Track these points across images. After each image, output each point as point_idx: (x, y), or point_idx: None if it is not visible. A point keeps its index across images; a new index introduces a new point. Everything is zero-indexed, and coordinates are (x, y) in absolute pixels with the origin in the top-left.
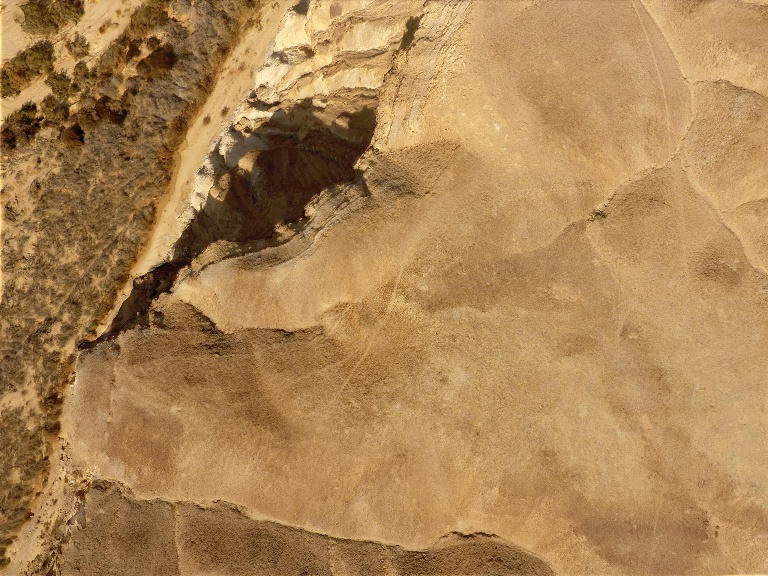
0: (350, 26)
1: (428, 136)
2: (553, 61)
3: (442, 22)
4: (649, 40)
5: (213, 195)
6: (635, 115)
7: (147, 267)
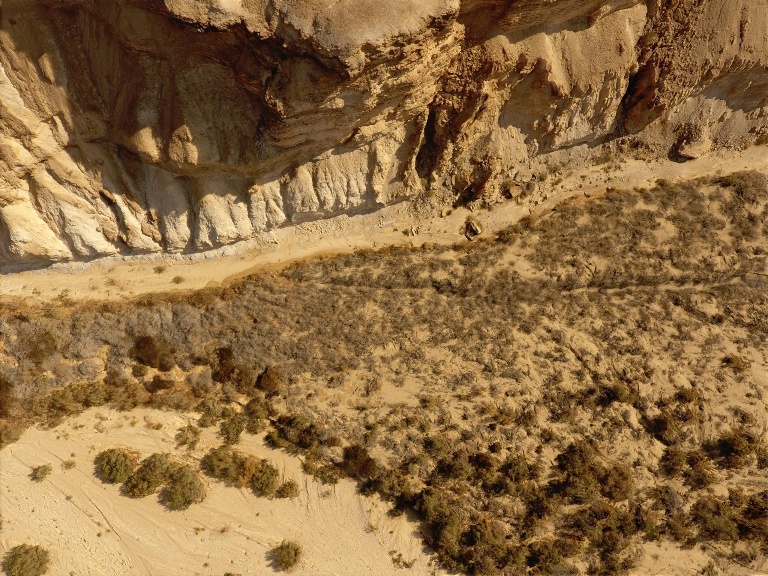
0: None
1: None
2: None
3: None
4: None
5: (196, 153)
6: None
7: (338, 242)
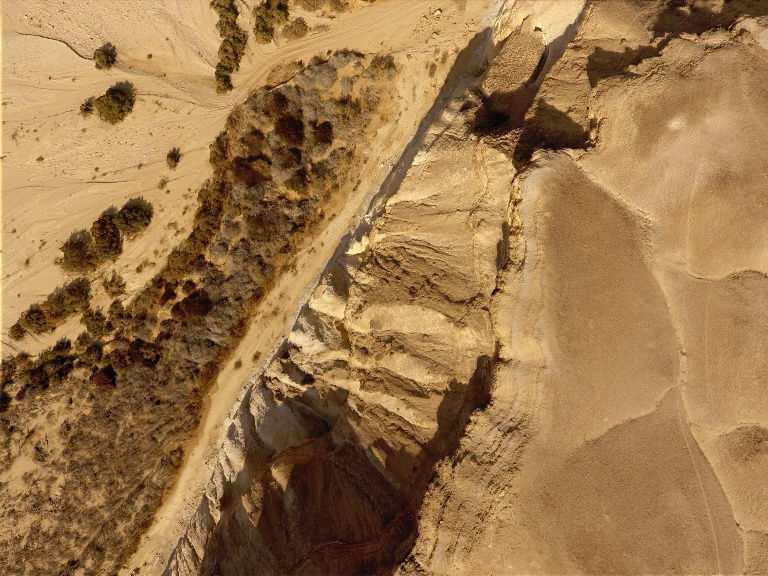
0: (390, 350)
1: (472, 574)
2: (604, 515)
3: (490, 443)
4: (702, 485)
5: (245, 507)
6: (686, 575)
7: (172, 511)
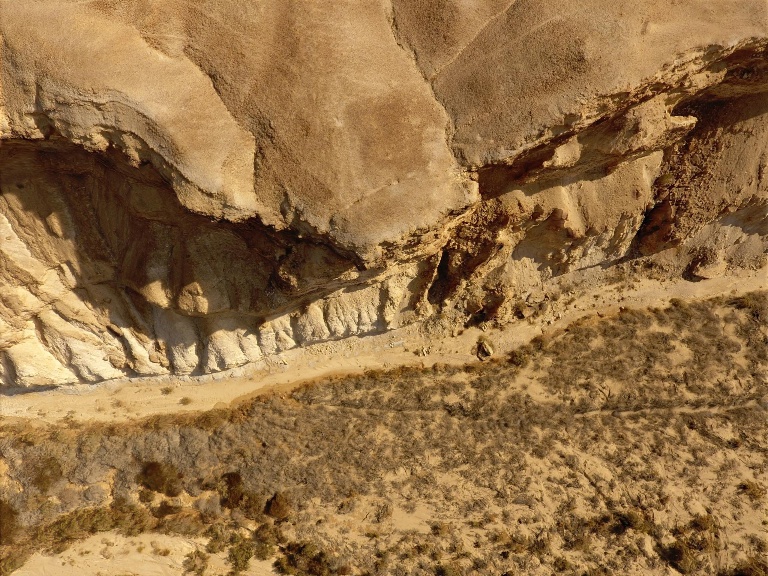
0: None
1: None
2: None
3: None
4: None
5: (206, 304)
6: None
7: (348, 362)
